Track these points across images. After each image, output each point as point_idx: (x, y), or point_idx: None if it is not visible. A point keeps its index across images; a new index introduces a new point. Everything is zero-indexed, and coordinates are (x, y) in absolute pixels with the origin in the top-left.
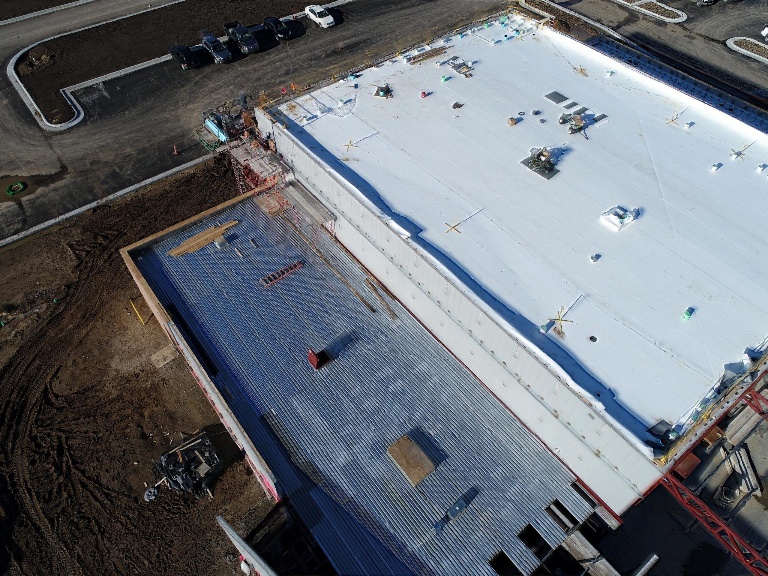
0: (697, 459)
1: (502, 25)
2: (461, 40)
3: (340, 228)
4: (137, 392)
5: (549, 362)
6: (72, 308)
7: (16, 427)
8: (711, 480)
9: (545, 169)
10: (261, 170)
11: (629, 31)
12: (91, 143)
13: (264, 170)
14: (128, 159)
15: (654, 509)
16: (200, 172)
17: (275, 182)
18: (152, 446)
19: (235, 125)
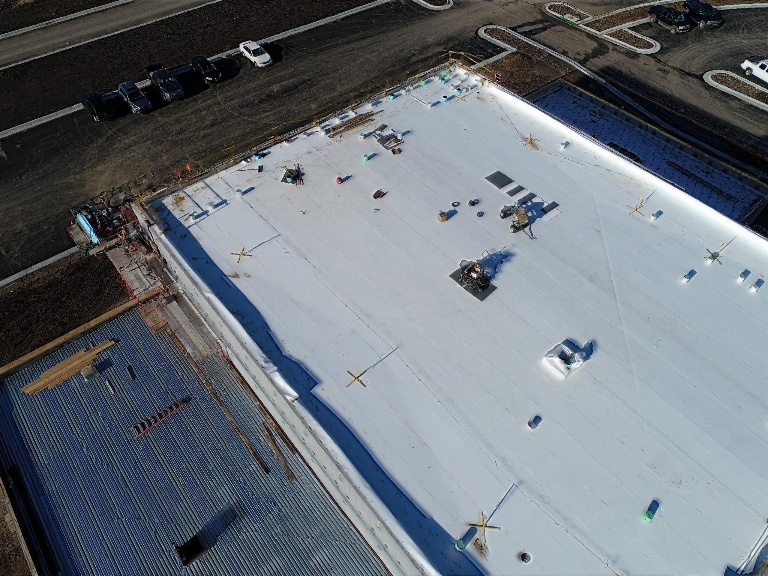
0: None
1: (442, 82)
2: (393, 102)
3: (232, 356)
4: None
5: None
6: None
7: None
8: None
9: (478, 286)
10: (135, 284)
11: (597, 65)
12: None
13: (139, 285)
14: (18, 237)
15: None
16: None
17: None
18: None
19: (113, 220)
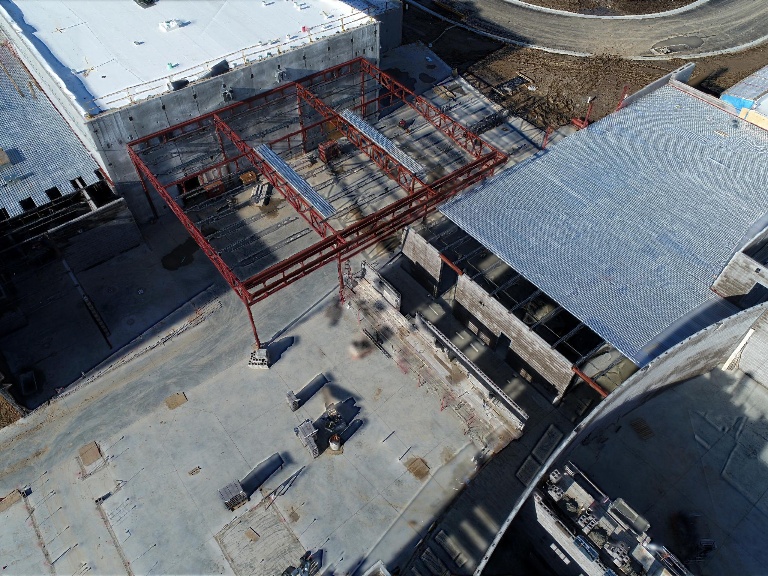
0: (220, 182)
1: None
2: None
3: (17, 50)
4: None
5: (60, 82)
6: None
7: None
8: None
9: None
10: None
11: None
12: None
13: None
14: None
15: (188, 213)
16: None
17: None
18: None
19: None
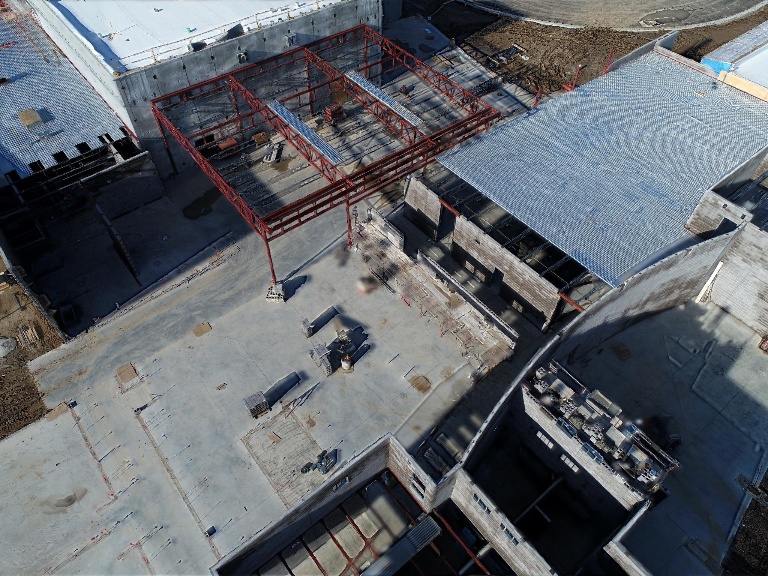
0: (235, 141)
1: None
2: None
3: (41, 20)
4: None
5: (88, 44)
6: None
7: None
8: None
9: None
10: None
11: None
12: None
13: None
14: None
15: None
16: None
17: None
18: None
19: None
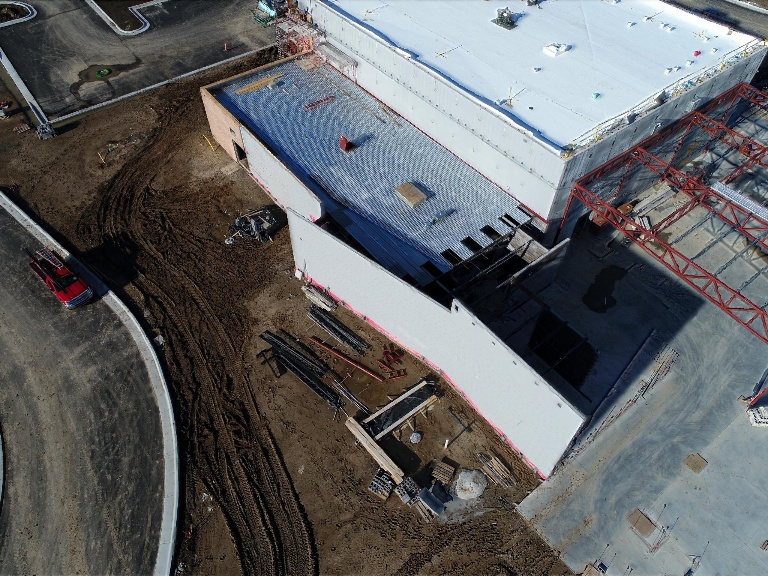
0: None
1: None
2: None
3: (360, 72)
4: (213, 188)
5: (500, 115)
6: (159, 142)
7: (129, 207)
8: (621, 234)
9: (507, 24)
10: (302, 32)
11: None
12: (158, 44)
13: (305, 32)
14: (188, 54)
15: (579, 248)
16: (246, 62)
17: (310, 51)
18: (227, 217)
19: (281, 6)
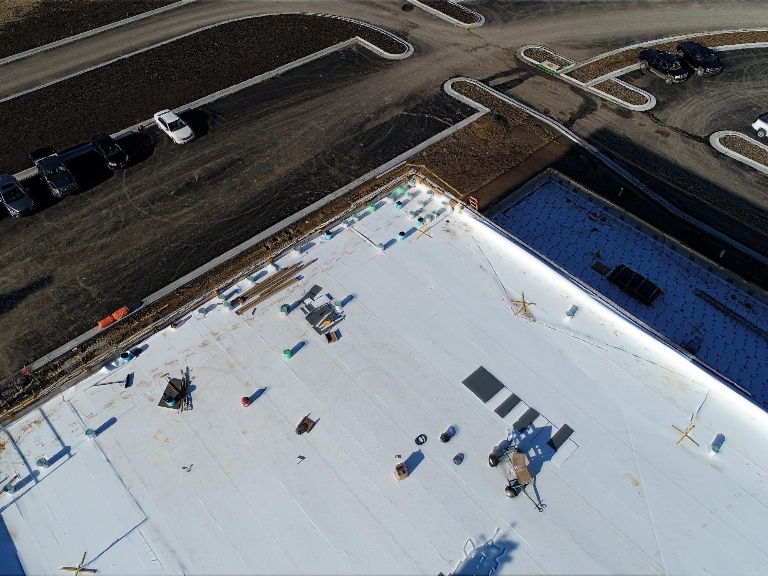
0: None
1: (398, 206)
2: (330, 244)
3: None
4: None
5: None
6: None
7: None
8: None
9: None
10: None
11: (586, 128)
12: None
13: None
14: None
15: None
16: None
17: None
18: None
19: None
